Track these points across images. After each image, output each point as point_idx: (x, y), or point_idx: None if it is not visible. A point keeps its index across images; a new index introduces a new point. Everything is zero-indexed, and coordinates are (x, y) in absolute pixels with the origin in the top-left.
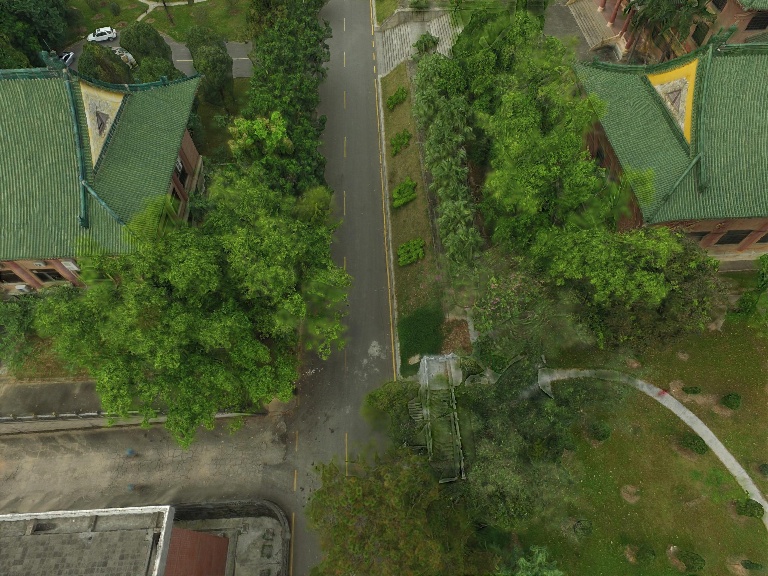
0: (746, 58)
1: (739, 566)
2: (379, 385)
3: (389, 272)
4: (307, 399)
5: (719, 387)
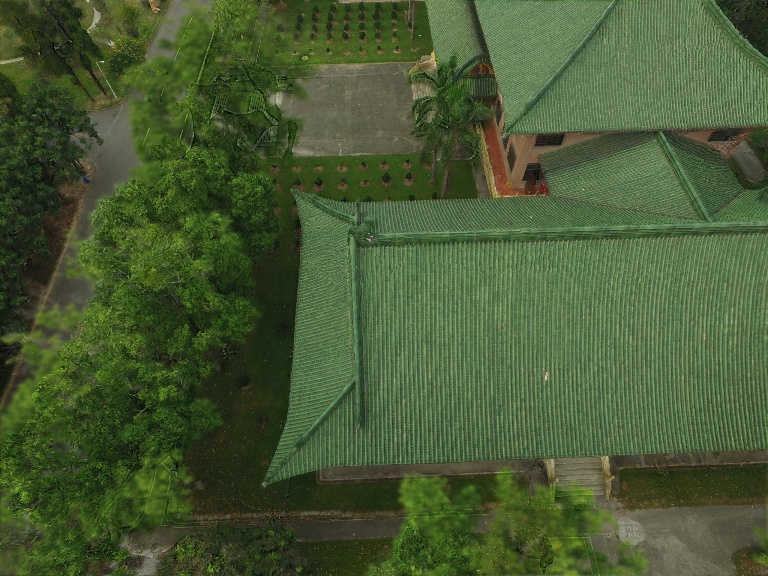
0: (411, 249)
1: None
2: None
3: None
4: None
5: None
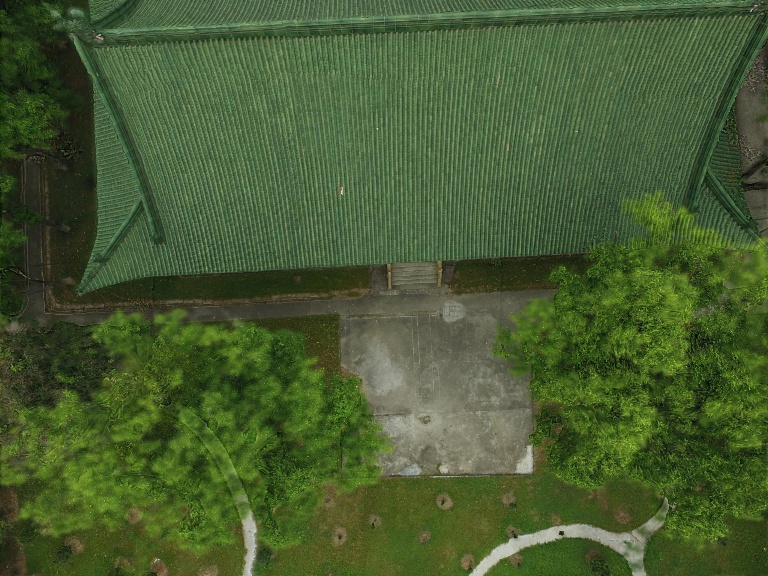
0: (158, 49)
1: (207, 575)
2: None
3: None
4: None
5: (257, 412)
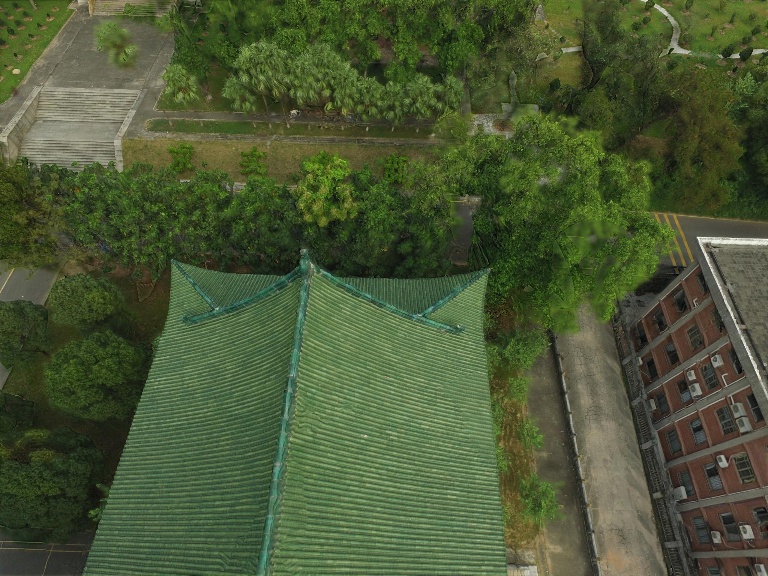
0: None
1: None
2: None
3: None
4: None
5: None
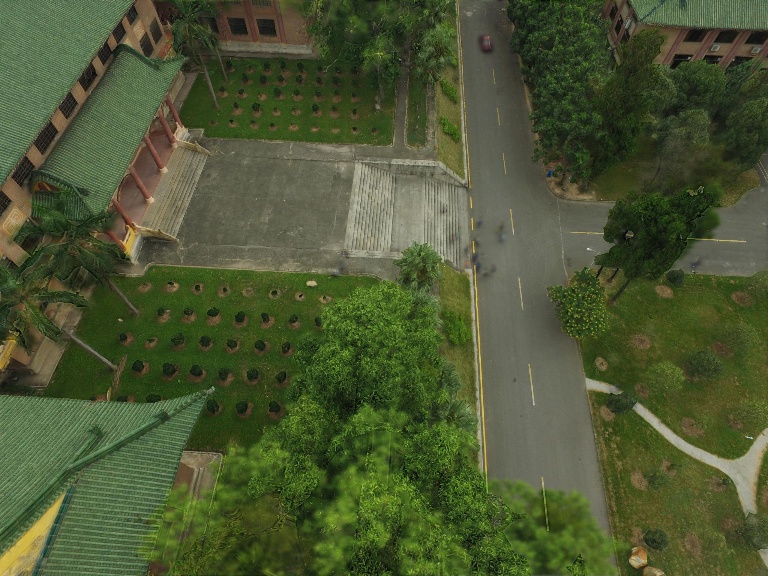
0: None
1: None
2: (467, 4)
3: (460, 40)
4: (504, 2)
5: None
